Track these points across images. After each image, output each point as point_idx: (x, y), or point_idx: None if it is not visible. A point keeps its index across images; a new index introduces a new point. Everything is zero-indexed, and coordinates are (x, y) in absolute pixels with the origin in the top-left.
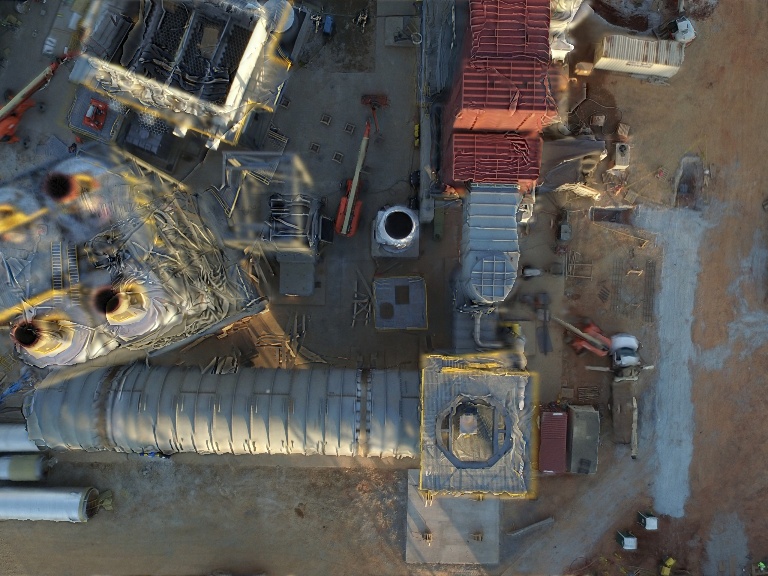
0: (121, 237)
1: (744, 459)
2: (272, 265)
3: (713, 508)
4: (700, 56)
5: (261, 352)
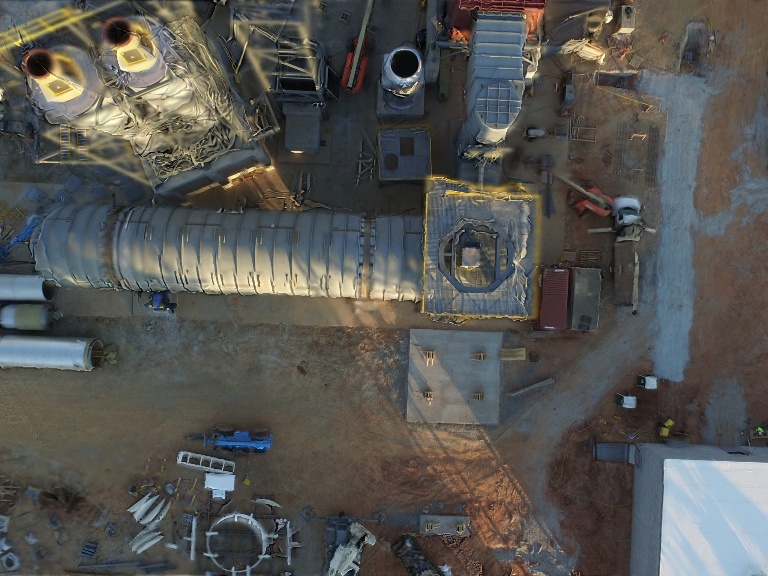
0: None
1: (744, 325)
2: (278, 118)
3: (712, 373)
4: None
5: (266, 201)
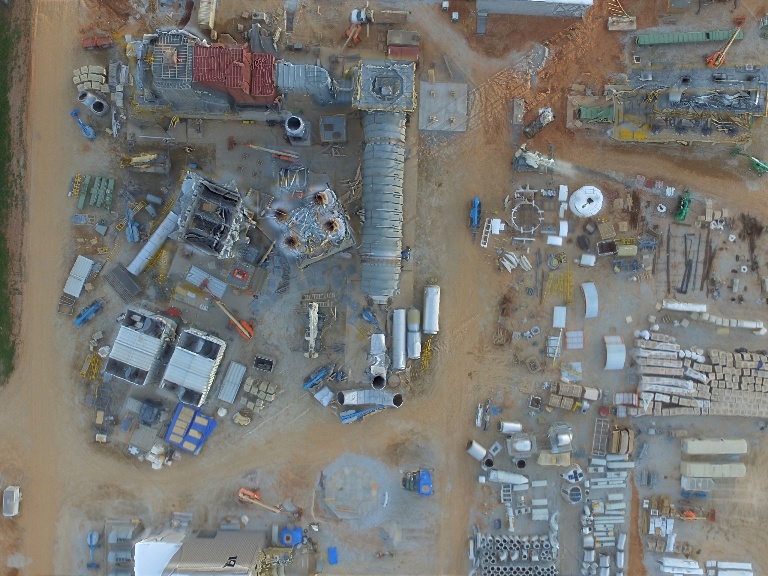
0: (299, 239)
1: None
2: (314, 194)
3: None
4: None
5: None
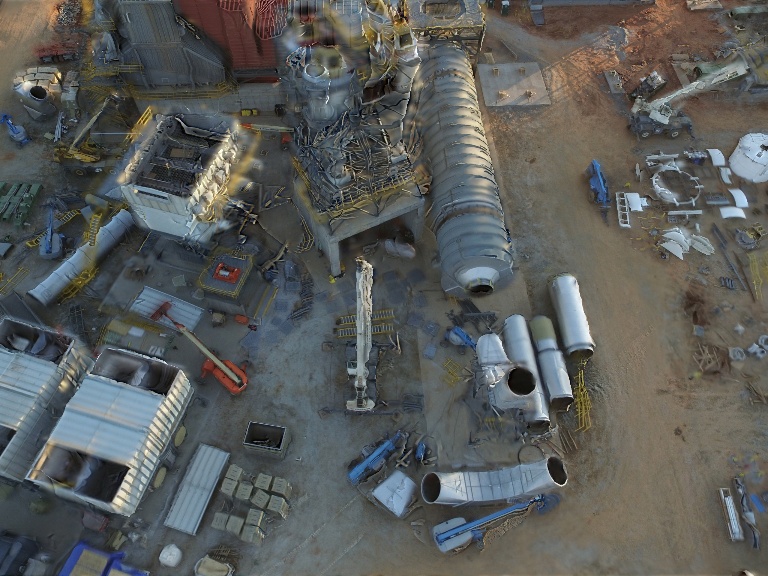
0: (331, 156)
1: None
2: None
3: None
4: None
5: None
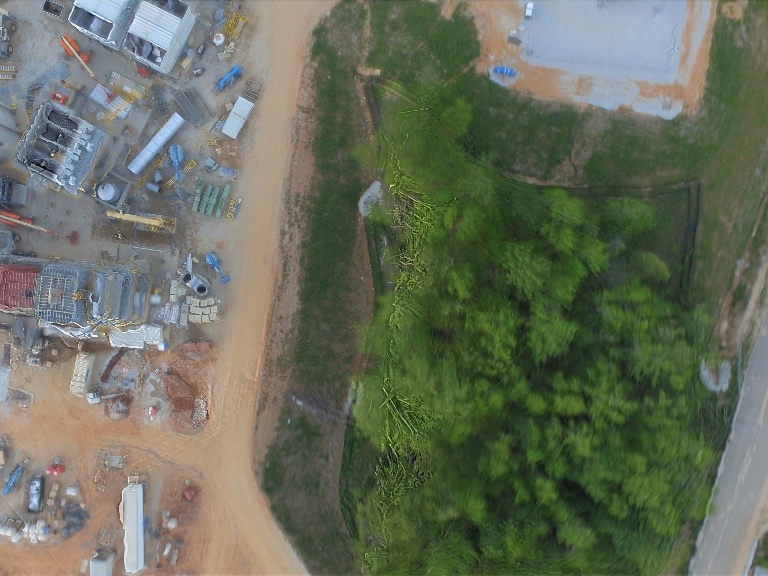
0: None
1: None
2: None
3: None
4: (86, 408)
5: None
